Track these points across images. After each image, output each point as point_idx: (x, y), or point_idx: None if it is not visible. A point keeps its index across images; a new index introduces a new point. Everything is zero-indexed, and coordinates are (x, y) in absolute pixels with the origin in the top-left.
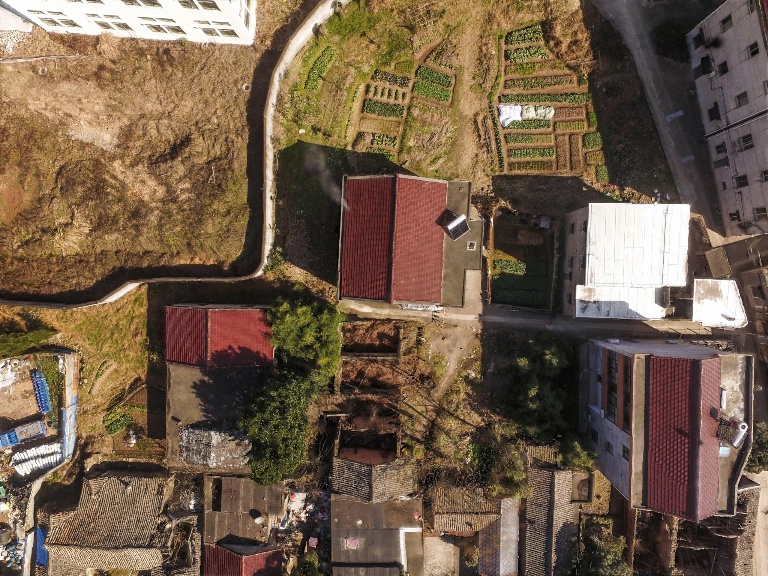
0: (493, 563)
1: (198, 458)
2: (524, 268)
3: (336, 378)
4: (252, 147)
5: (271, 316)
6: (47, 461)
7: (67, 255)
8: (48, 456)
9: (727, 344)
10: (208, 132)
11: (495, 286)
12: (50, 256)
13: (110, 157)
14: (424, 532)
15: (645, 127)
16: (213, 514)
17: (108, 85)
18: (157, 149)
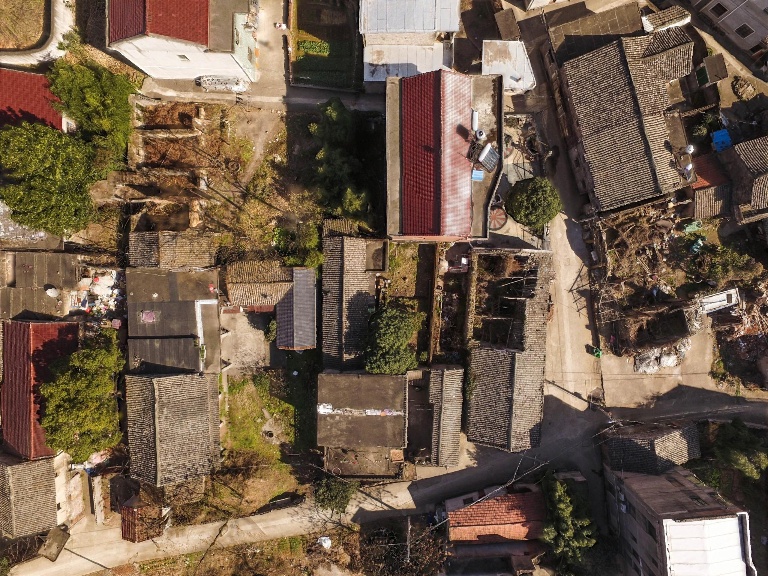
0: (288, 333)
1: None
2: (328, 48)
3: (129, 151)
4: None
5: (50, 76)
6: None
7: None
8: None
9: (526, 117)
10: None
11: (299, 67)
12: None
13: None
14: (221, 305)
15: None
16: (8, 290)
17: None
18: None
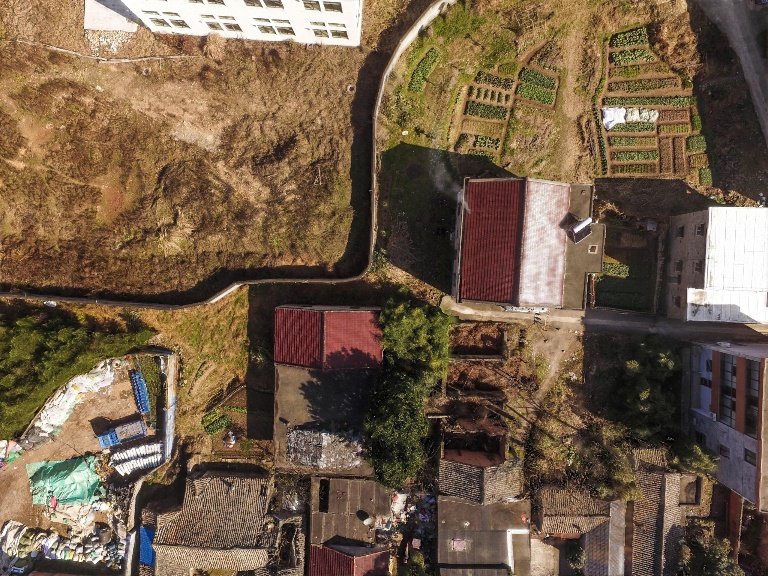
0: (601, 565)
1: (307, 459)
2: (627, 271)
3: (443, 380)
4: (356, 149)
5: (385, 318)
6: (148, 461)
7: (169, 256)
8: (149, 456)
9: None
10: (313, 133)
11: (597, 289)
12: (152, 257)
13: (213, 158)
14: (531, 534)
15: (751, 130)
16: (320, 515)
17: (212, 86)
18: (260, 150)
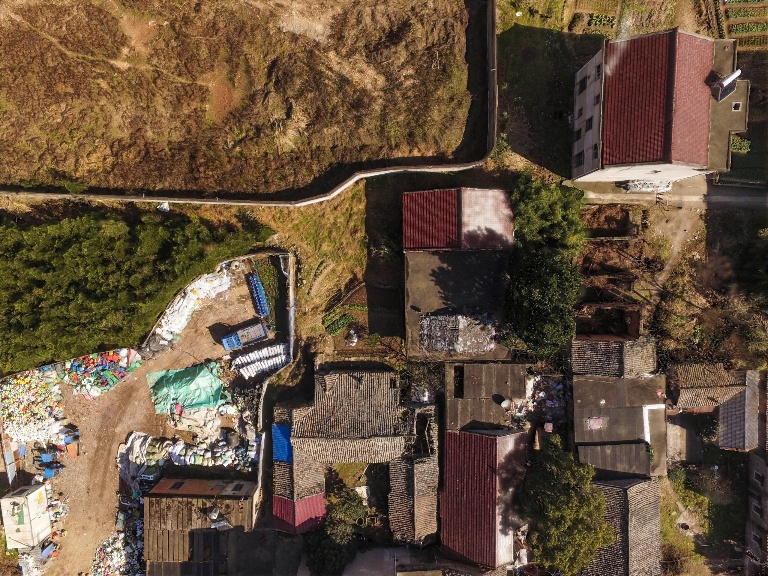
0: (737, 435)
1: (443, 344)
2: (748, 145)
3: (574, 260)
4: (470, 32)
5: (519, 194)
6: (272, 363)
7: (282, 153)
8: (273, 358)
9: None
10: (426, 17)
11: None
12: (266, 154)
13: (324, 48)
14: (666, 409)
15: None
16: (455, 401)
17: None
18: (372, 38)
